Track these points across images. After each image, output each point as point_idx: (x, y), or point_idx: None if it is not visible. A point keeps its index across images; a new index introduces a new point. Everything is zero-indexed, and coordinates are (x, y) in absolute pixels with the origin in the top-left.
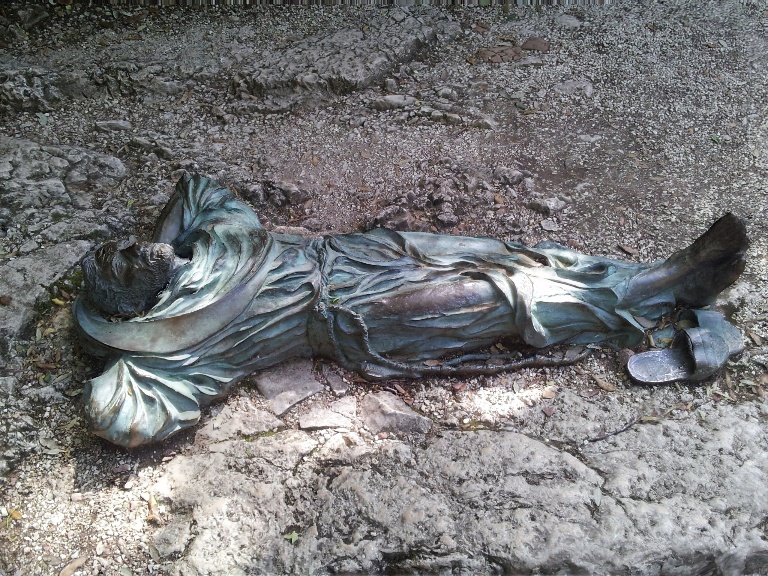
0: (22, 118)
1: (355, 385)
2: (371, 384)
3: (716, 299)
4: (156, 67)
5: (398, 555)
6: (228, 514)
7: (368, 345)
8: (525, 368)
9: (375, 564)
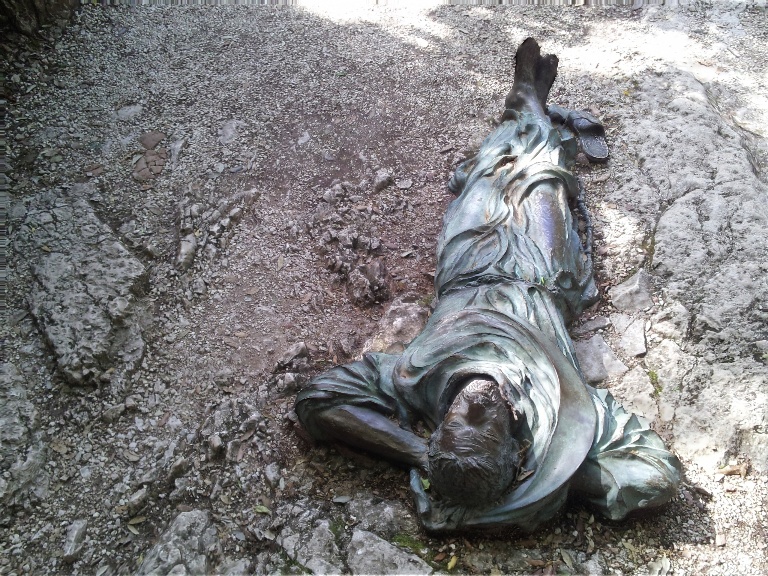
0: None
1: (599, 312)
2: (602, 299)
3: None
4: None
5: None
6: (748, 401)
7: None
8: None
9: None
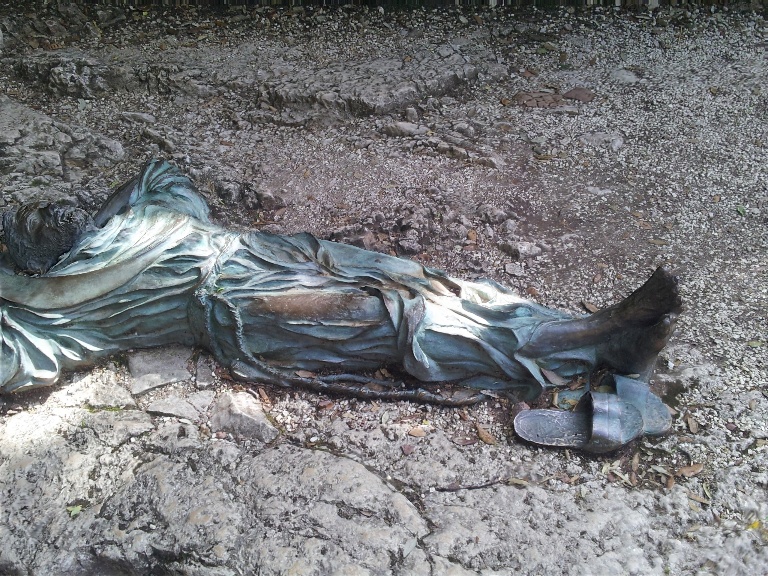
0: (65, 101)
1: (221, 381)
2: (235, 383)
3: (649, 369)
4: (195, 71)
5: (169, 555)
6: (29, 474)
7: (241, 342)
8: (405, 401)
9: (143, 558)
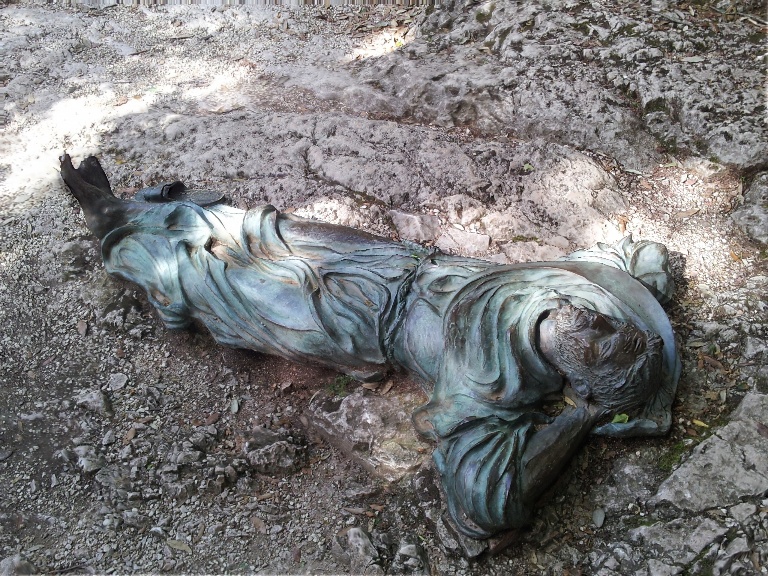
0: None
1: None
2: None
3: None
4: None
5: None
6: None
7: None
8: None
9: None
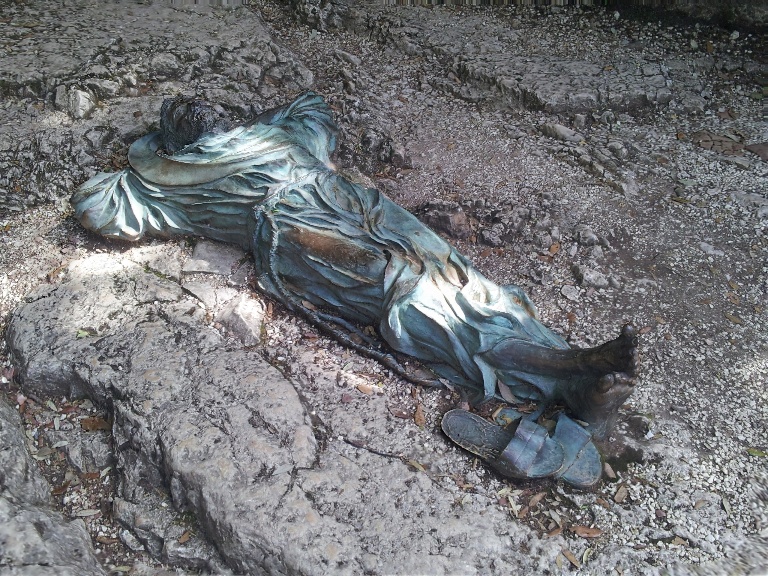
0: (302, 28)
1: (248, 286)
2: (254, 291)
3: (601, 423)
4: (413, 30)
5: (119, 393)
6: (74, 297)
7: (272, 259)
8: (375, 360)
9: (103, 388)
